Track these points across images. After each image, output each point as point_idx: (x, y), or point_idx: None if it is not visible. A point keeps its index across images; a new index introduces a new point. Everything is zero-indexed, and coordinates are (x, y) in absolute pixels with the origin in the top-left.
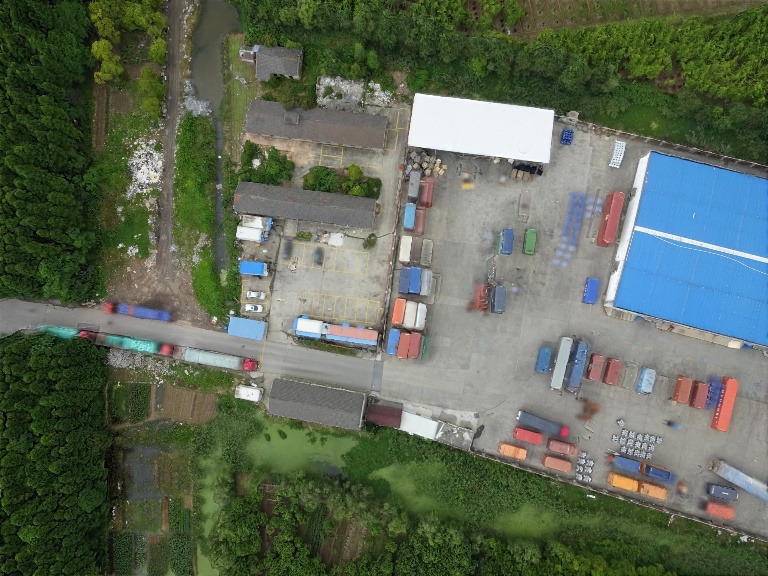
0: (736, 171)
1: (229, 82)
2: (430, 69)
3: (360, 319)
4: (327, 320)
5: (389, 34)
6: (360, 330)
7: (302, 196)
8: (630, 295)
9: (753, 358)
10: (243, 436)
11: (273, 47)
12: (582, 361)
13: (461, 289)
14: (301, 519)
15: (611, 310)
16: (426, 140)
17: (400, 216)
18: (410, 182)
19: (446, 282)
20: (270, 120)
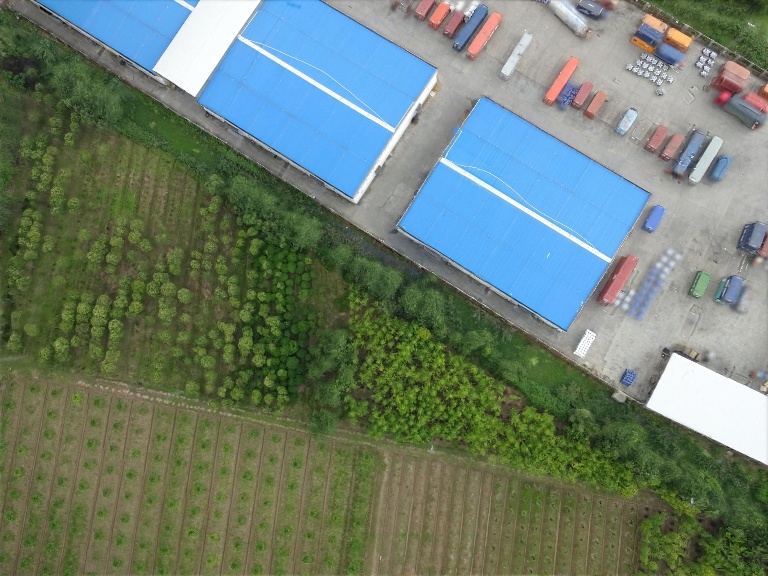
0: None
1: None
2: (750, 499)
3: None
4: None
5: None
6: None
7: None
8: (632, 200)
9: None
10: None
11: None
12: (687, 155)
13: None
14: None
15: None
16: None
17: None
18: None
19: None
20: None
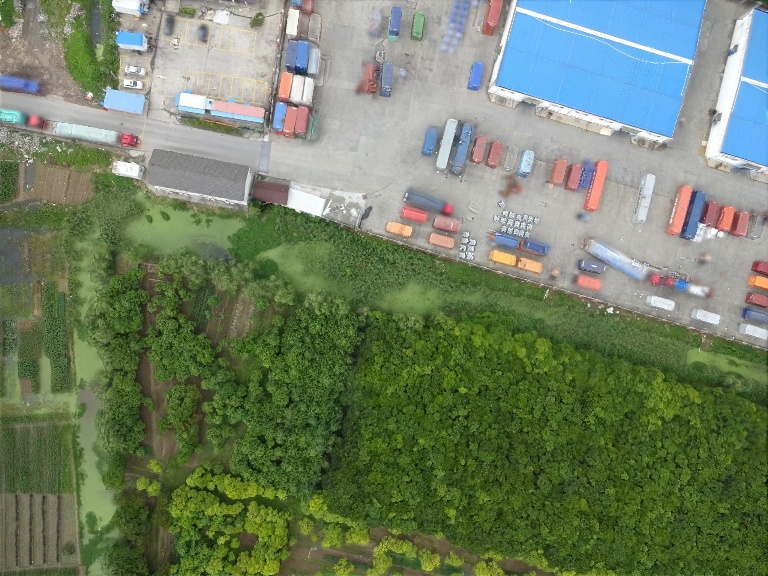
0: None
1: None
2: None
3: (247, 99)
4: None
5: None
6: (246, 106)
7: None
8: (511, 75)
9: (622, 145)
10: (122, 215)
11: None
12: (466, 142)
13: (350, 72)
14: (185, 295)
15: (494, 96)
16: None
17: None
18: None
19: (335, 65)
20: None
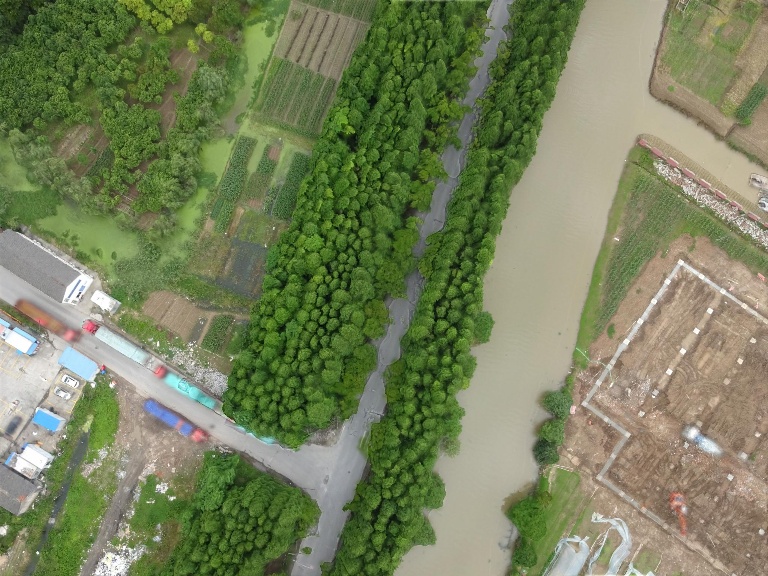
0: None
1: None
2: None
3: None
4: None
5: None
6: None
7: None
8: None
9: None
10: (131, 265)
11: None
12: None
13: None
14: (105, 173)
15: None
16: None
17: None
18: None
19: None
20: None
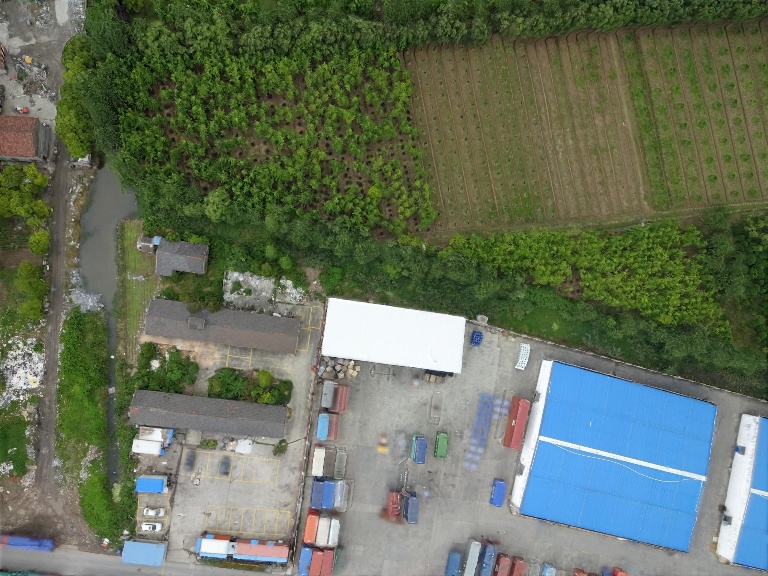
0: (626, 380)
1: (124, 273)
2: (344, 266)
3: (269, 531)
4: (234, 534)
5: (303, 240)
6: (270, 547)
7: (207, 407)
8: (534, 502)
9: (638, 548)
10: None
11: (176, 242)
12: (490, 565)
13: (374, 495)
14: None
15: (516, 510)
16: (340, 349)
17: (312, 421)
18: (324, 392)
19: (359, 488)
20: (172, 324)
